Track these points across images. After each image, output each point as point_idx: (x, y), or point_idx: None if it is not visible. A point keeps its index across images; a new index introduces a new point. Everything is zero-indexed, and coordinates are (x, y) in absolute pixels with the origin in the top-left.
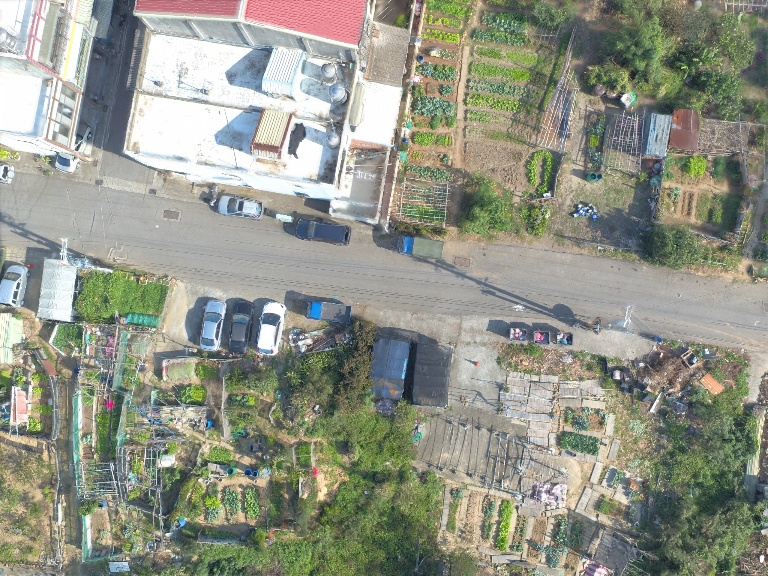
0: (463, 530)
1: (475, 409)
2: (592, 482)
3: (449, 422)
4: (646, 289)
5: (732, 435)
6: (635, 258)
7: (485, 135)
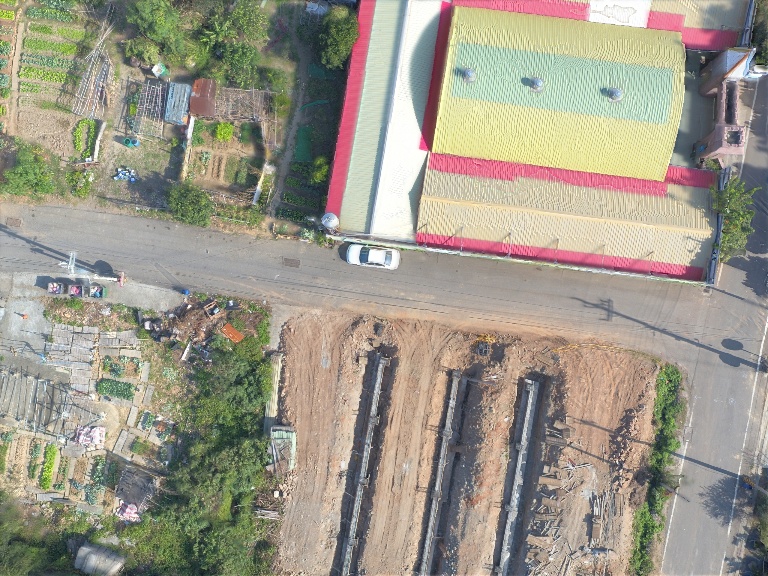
0: (11, 471)
1: (24, 359)
2: (129, 425)
3: (0, 371)
4: (178, 246)
5: (246, 379)
6: (169, 217)
7: (36, 105)
